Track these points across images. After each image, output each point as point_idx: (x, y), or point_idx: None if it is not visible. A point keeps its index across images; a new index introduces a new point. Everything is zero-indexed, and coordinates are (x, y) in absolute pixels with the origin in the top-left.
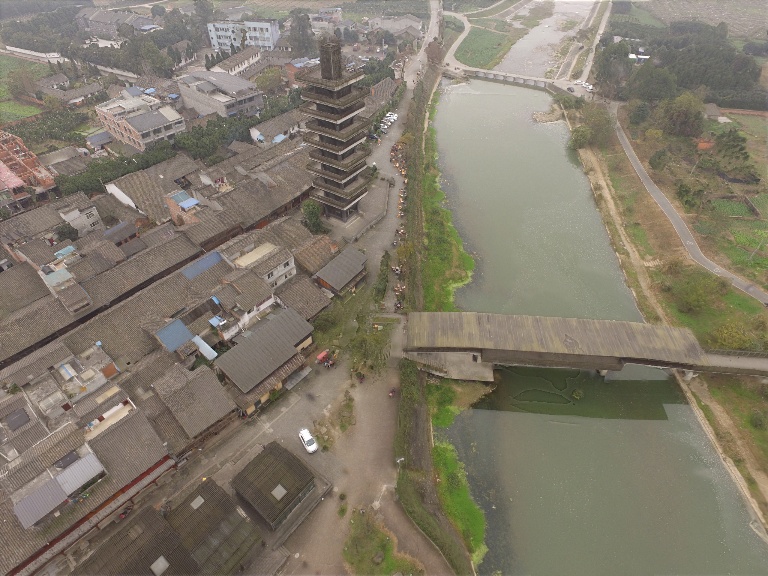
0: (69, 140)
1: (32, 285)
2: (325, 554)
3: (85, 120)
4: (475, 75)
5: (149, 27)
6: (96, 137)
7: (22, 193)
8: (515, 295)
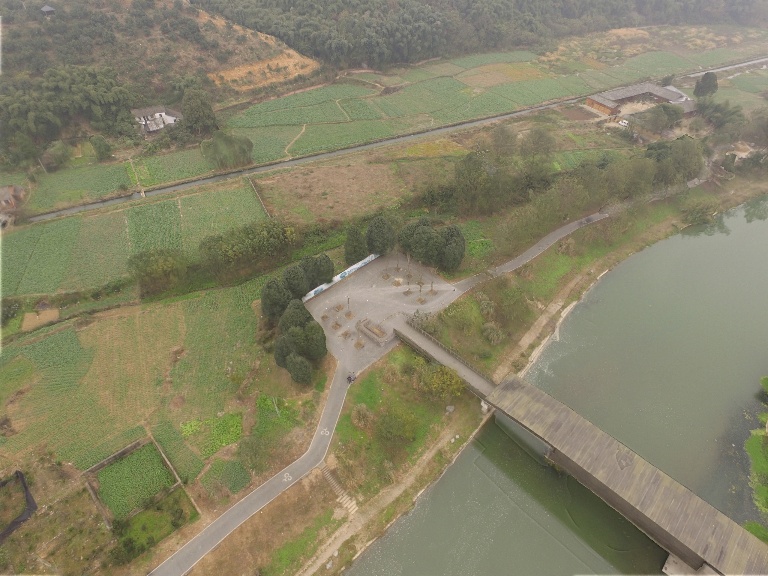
0: None
1: None
2: None
3: None
4: None
5: None
6: None
7: None
8: None
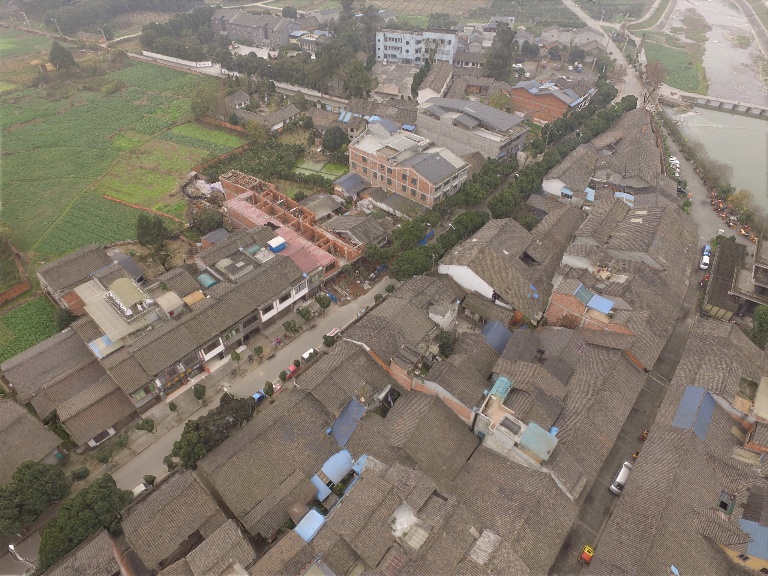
0: (306, 182)
1: (454, 433)
2: None
3: (300, 153)
4: (696, 102)
5: (300, 33)
6: (348, 182)
7: (331, 270)
8: None
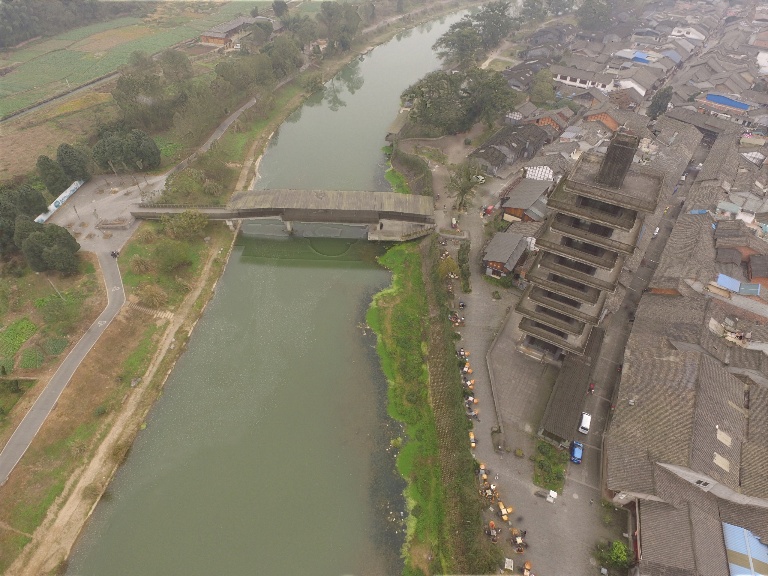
0: None
1: None
2: (455, 156)
3: None
4: None
5: None
6: None
7: None
8: (333, 280)
